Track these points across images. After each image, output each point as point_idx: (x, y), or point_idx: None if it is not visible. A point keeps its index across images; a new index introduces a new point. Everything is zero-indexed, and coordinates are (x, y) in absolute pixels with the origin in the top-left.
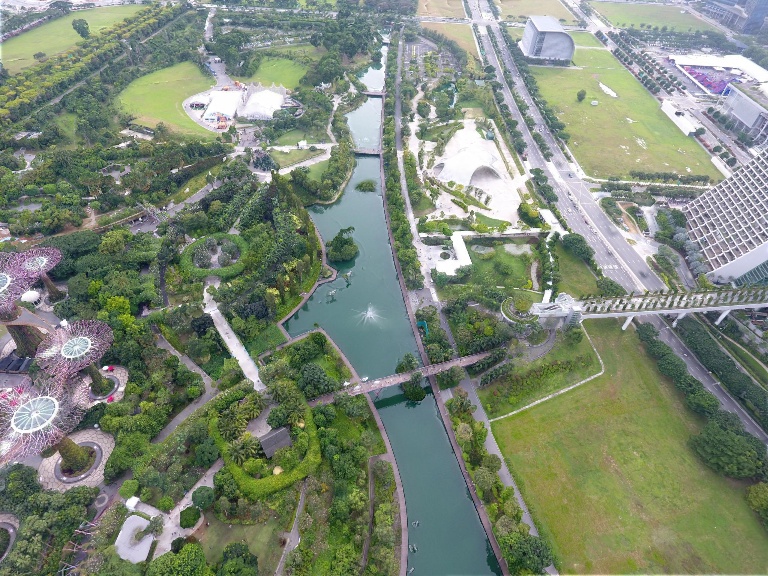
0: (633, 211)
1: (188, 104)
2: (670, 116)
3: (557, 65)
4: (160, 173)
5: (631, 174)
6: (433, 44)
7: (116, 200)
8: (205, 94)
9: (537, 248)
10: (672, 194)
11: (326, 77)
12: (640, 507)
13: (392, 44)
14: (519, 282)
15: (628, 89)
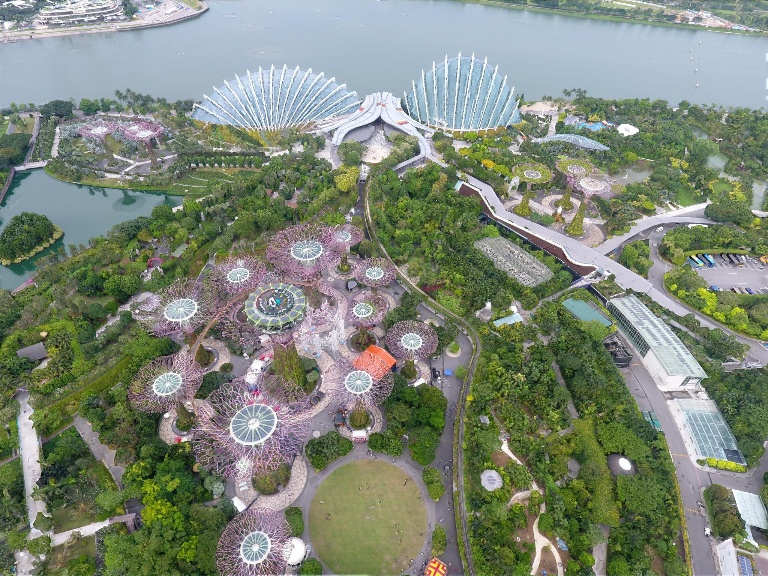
0: None
1: None
2: None
3: None
4: None
5: None
6: None
7: None
8: None
9: None
10: None
11: None
12: None
13: None
14: None
15: None
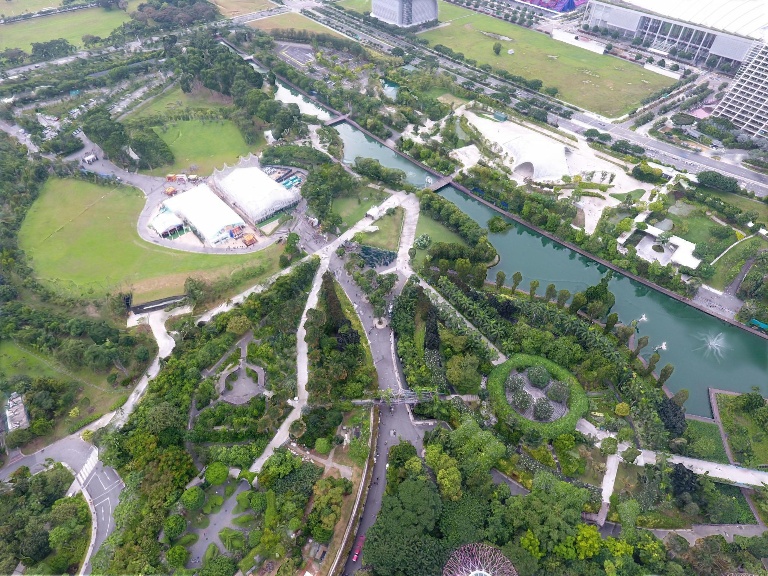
0: (679, 133)
1: (153, 235)
2: (570, 42)
3: (429, 27)
4: (317, 344)
5: (643, 102)
6: (296, 44)
7: (340, 418)
8: (152, 211)
9: (691, 200)
10: (687, 106)
11: (285, 123)
12: None
13: (270, 58)
14: (731, 236)
15: (507, 30)
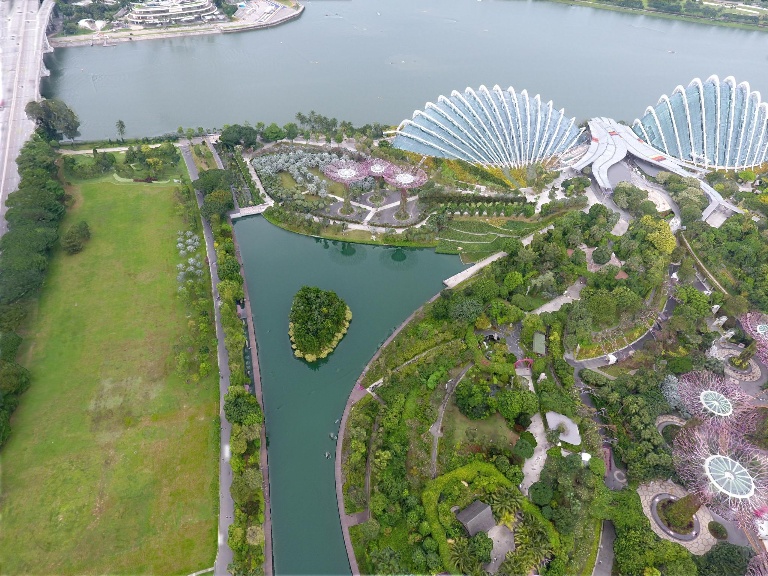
0: None
1: None
2: None
3: None
4: None
5: None
6: None
7: None
8: None
9: None
10: None
11: None
12: (108, 461)
13: None
14: None
15: None
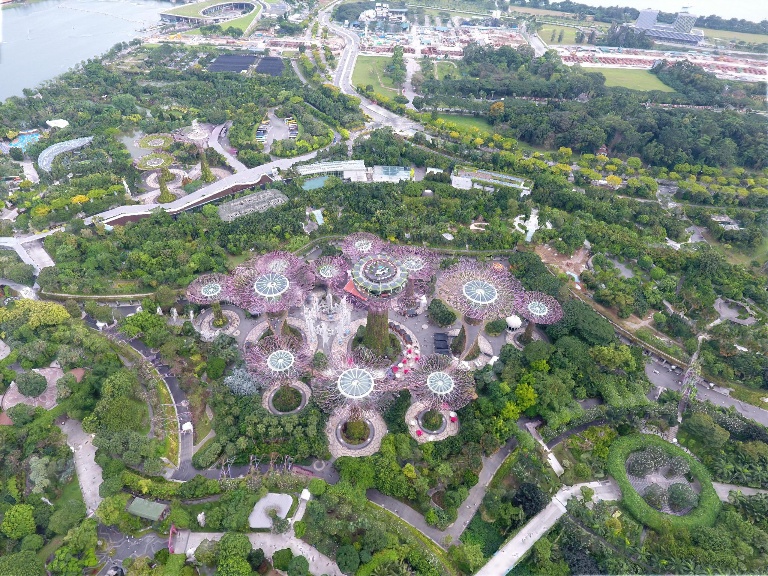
0: None
1: None
2: None
3: None
4: None
5: None
6: None
7: (680, 332)
8: None
9: None
10: None
11: None
12: None
13: None
14: None
15: None
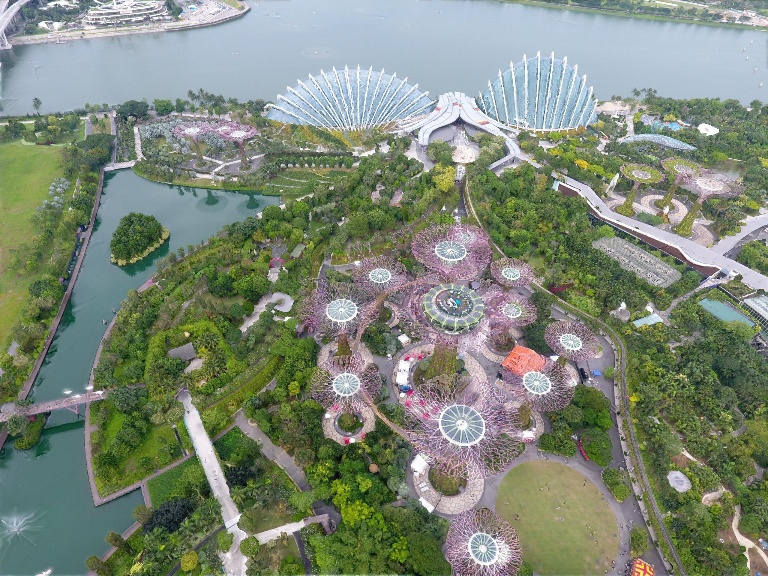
0: None
1: None
2: None
3: None
4: None
5: None
6: None
7: None
8: None
9: None
10: None
11: None
12: None
13: None
14: None
15: None
